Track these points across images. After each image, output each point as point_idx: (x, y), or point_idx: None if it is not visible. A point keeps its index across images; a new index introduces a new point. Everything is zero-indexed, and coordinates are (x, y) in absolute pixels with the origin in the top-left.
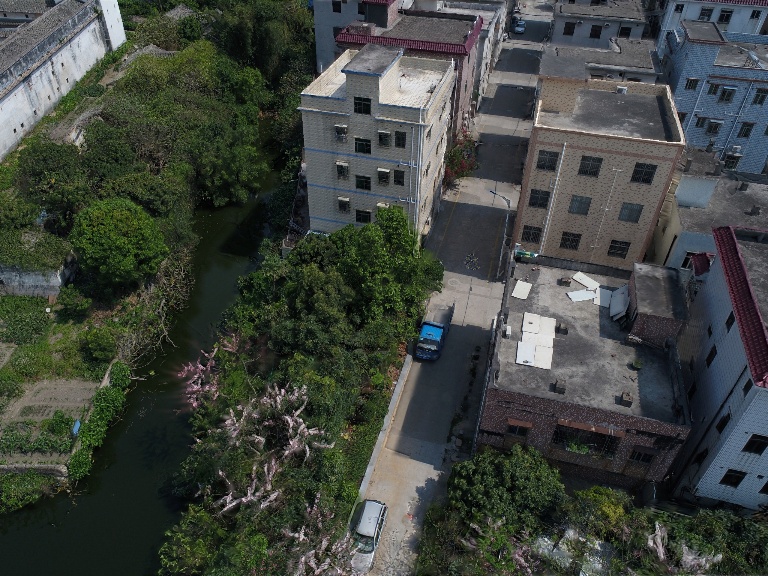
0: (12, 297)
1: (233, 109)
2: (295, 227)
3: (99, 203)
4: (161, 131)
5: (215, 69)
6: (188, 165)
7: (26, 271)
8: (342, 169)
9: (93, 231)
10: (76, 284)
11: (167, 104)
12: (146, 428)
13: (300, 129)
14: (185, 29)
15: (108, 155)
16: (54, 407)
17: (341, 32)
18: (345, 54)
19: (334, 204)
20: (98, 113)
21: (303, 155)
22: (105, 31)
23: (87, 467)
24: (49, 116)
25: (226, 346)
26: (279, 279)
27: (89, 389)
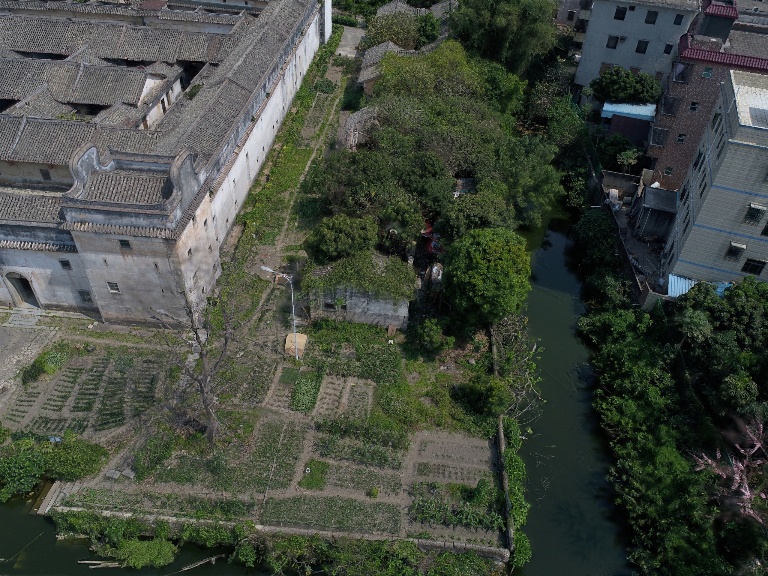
0: (350, 324)
1: (498, 119)
2: (638, 266)
3: (483, 232)
4: (457, 142)
5: (486, 75)
6: (506, 185)
7: (377, 298)
8: (756, 213)
9: (489, 266)
10: (412, 314)
11: (455, 112)
12: (556, 503)
13: (578, 147)
14: (426, 27)
15: (421, 168)
16: (453, 467)
17: (689, 47)
18: (733, 76)
19: (720, 249)
20: (376, 116)
21: (603, 179)
22: (322, 23)
23: (529, 553)
24: (291, 112)
25: (625, 410)
26: (651, 330)
27: (481, 448)
